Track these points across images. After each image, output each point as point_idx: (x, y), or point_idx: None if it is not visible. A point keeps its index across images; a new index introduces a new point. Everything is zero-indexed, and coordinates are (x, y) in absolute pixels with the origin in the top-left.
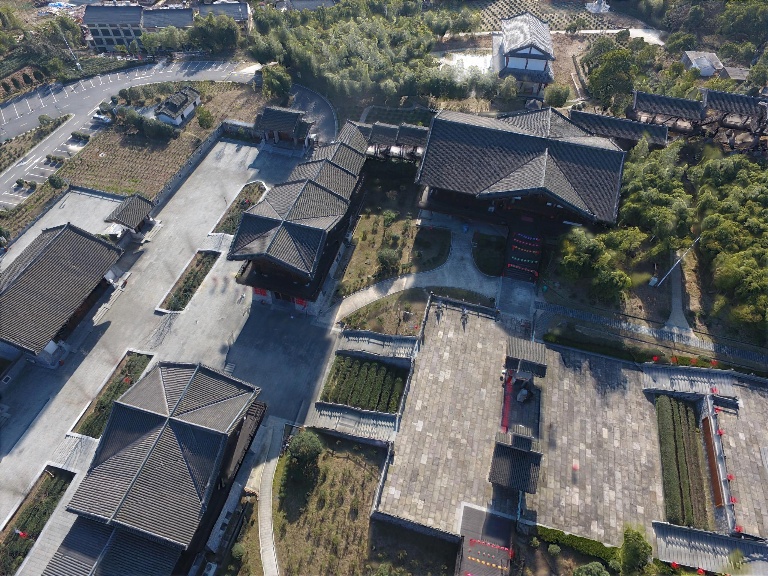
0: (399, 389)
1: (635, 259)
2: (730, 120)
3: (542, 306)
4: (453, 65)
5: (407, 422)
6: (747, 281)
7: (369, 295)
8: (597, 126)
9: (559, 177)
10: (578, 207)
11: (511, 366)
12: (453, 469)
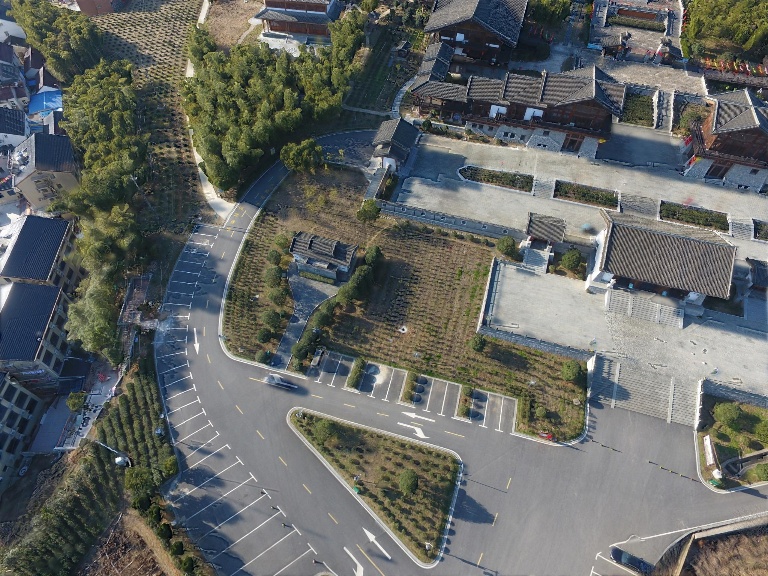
0: (637, 95)
1: None
2: None
3: (566, 43)
4: (344, 25)
5: None
6: None
7: None
8: None
9: None
10: None
11: None
12: (674, 77)
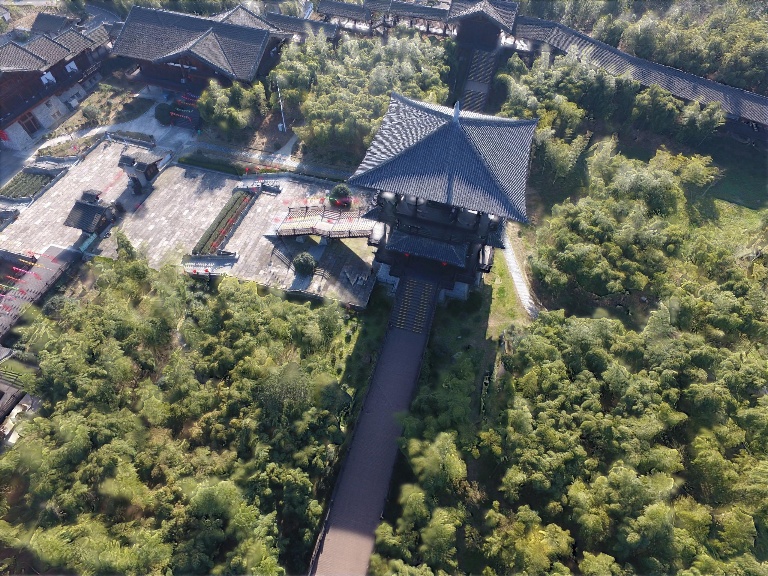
0: None
1: (259, 106)
2: (387, 20)
3: (191, 143)
4: None
5: (39, 202)
6: (309, 110)
7: (67, 138)
8: (285, 24)
9: (215, 48)
10: (219, 67)
11: (122, 165)
12: (56, 227)
